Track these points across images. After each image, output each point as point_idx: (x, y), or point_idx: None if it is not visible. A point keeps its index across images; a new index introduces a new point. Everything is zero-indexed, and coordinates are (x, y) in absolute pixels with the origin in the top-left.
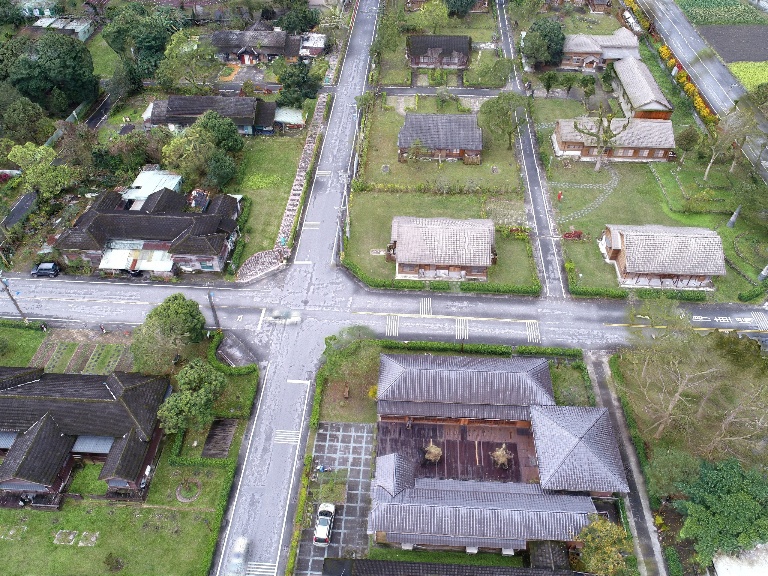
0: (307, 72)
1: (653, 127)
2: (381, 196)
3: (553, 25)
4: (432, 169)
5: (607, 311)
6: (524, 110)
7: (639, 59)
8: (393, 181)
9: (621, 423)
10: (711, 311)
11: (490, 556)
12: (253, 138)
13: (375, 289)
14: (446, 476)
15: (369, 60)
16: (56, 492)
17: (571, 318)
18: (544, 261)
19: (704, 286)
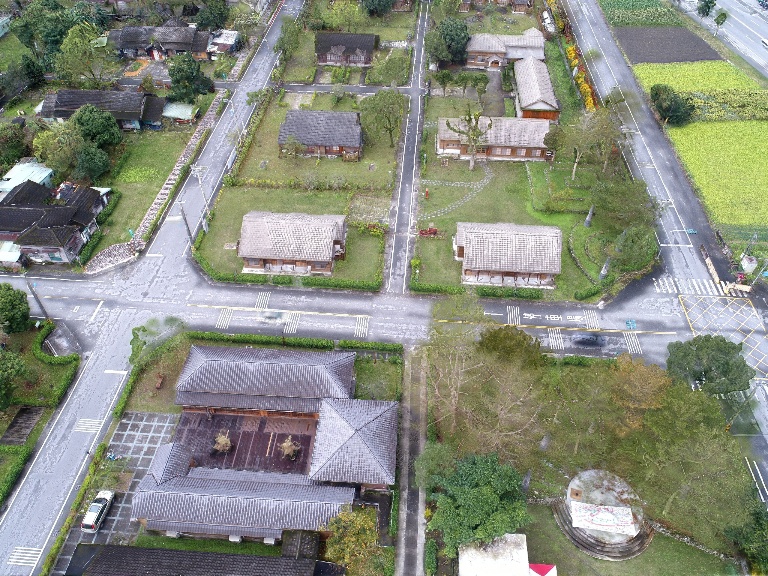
0: (198, 68)
1: (530, 126)
2: (251, 191)
3: (457, 24)
4: (309, 165)
5: (441, 307)
6: (418, 108)
7: (543, 59)
8: (267, 177)
9: (422, 417)
10: (544, 309)
11: (255, 545)
12: (141, 133)
13: (218, 282)
14: (232, 466)
15: (278, 57)
16: None
17: (403, 314)
18: (394, 257)
19: (545, 284)
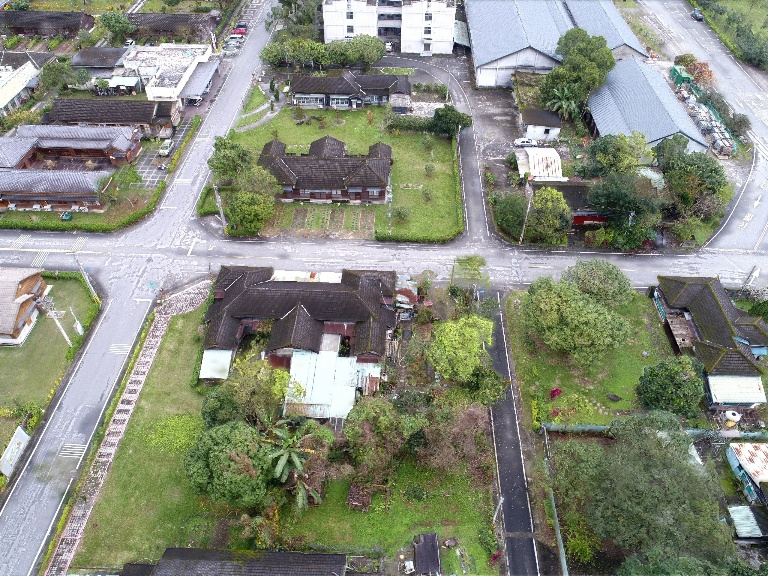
0: None
1: None
2: (7, 401)
3: None
4: None
5: None
6: None
7: None
8: None
9: None
10: None
11: None
12: None
13: None
14: None
15: None
16: None
17: None
18: None
19: None
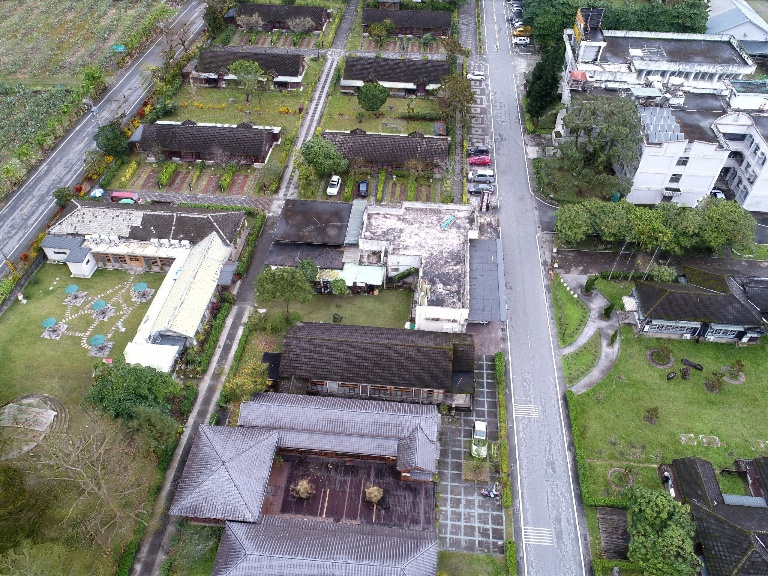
0: None
1: None
2: None
3: None
4: None
5: None
6: None
7: None
8: None
9: (149, 538)
10: None
11: None
12: None
13: None
14: (363, 479)
15: None
16: (749, 471)
17: None
18: None
19: None
